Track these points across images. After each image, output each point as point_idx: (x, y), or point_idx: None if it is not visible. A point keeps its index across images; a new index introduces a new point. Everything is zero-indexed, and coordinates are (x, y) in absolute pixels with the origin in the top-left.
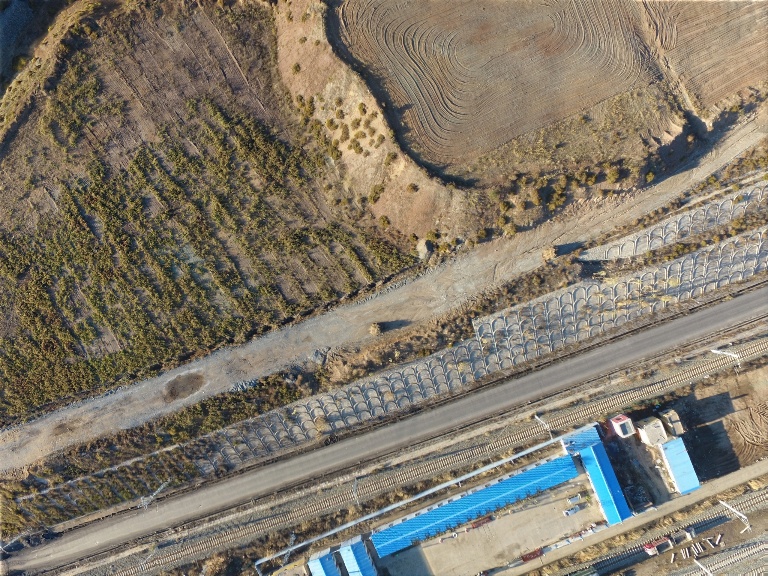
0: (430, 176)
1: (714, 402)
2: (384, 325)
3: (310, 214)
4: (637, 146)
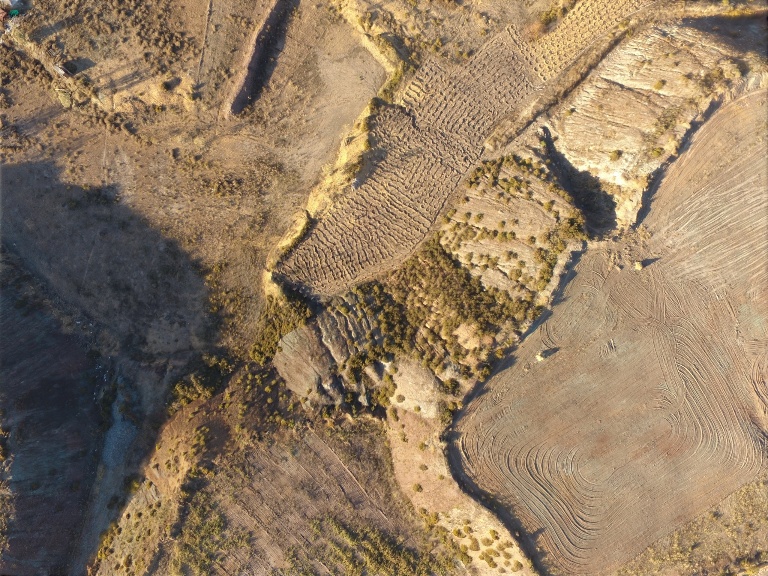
0: None
1: None
2: None
3: None
4: None
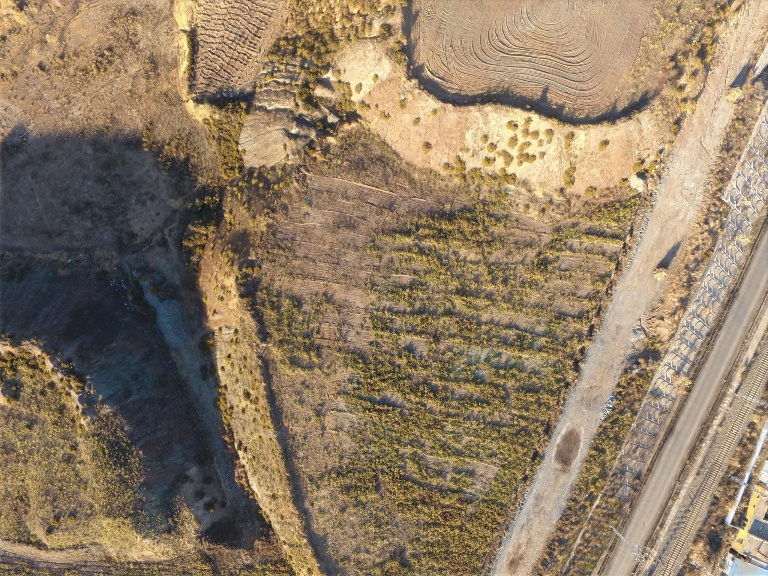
0: (612, 123)
1: None
2: (662, 264)
3: (531, 240)
4: None
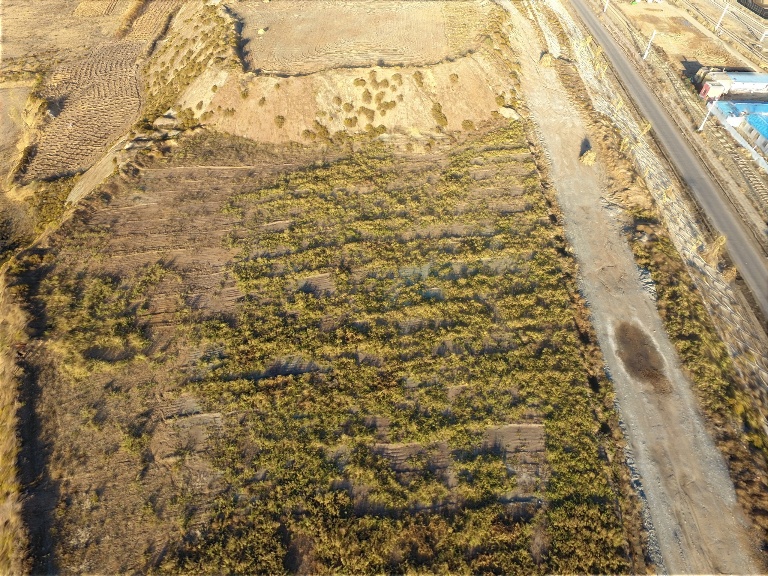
0: (451, 61)
1: (689, 65)
2: None
3: (428, 167)
4: (484, 8)
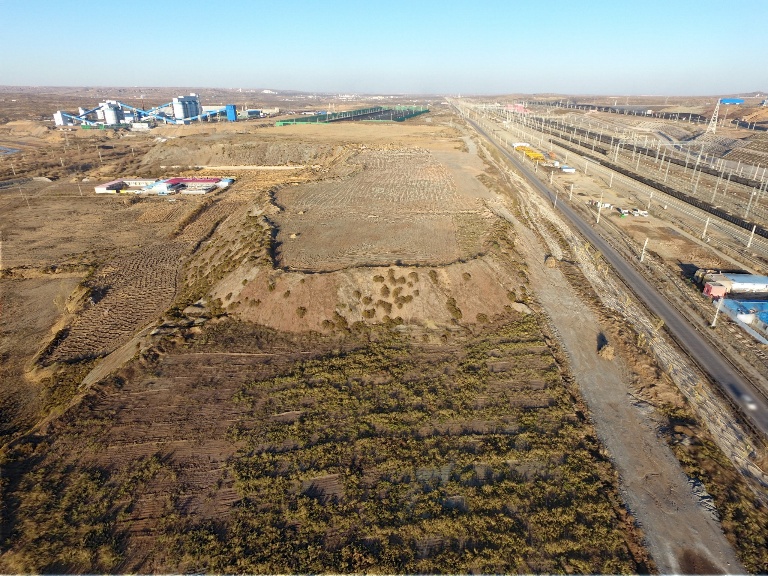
0: None
1: (685, 267)
2: None
3: (445, 358)
4: (489, 220)
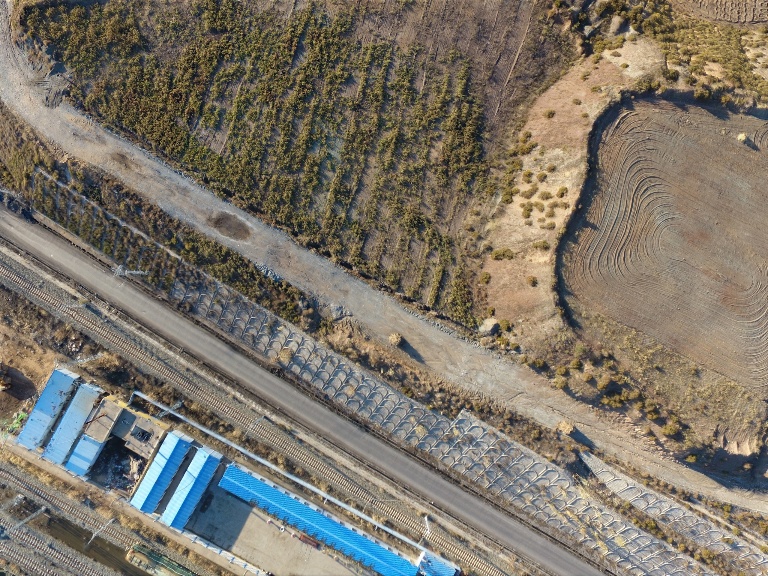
0: (554, 288)
1: None
2: (404, 343)
3: (444, 215)
4: (708, 430)
